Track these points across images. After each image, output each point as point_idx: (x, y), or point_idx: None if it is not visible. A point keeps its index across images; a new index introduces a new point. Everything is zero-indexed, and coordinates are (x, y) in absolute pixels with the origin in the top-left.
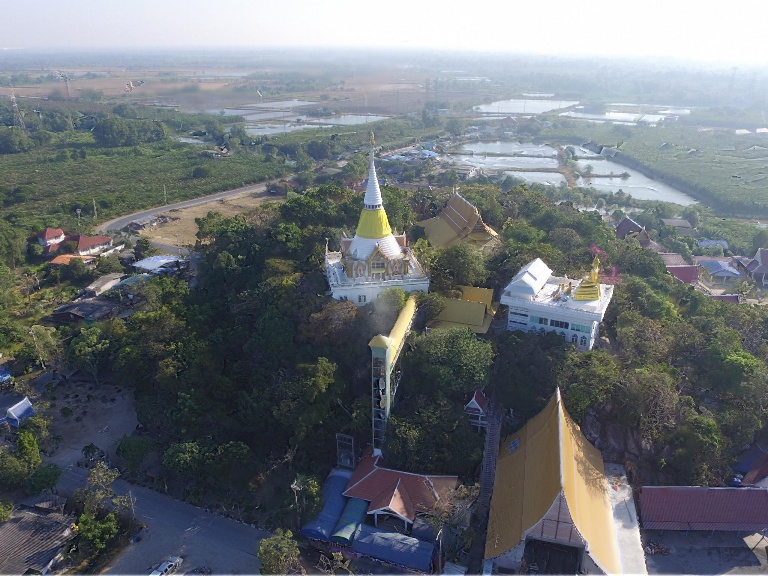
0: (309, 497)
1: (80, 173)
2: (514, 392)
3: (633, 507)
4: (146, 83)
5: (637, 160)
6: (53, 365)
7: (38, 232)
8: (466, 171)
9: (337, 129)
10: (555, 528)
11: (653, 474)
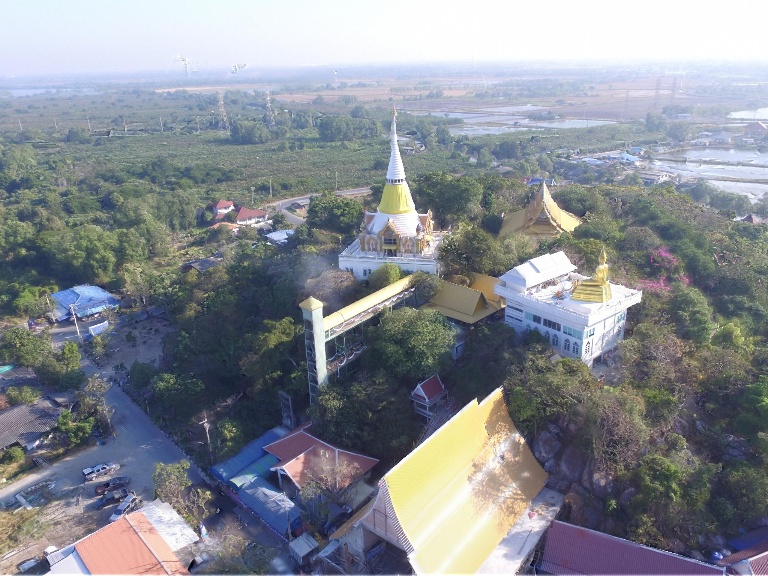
0: (226, 440)
1: (288, 161)
2: (466, 387)
3: (534, 540)
4: (248, 65)
5: None
6: (138, 300)
7: (215, 202)
8: (654, 176)
9: (546, 132)
10: (384, 522)
11: (602, 516)
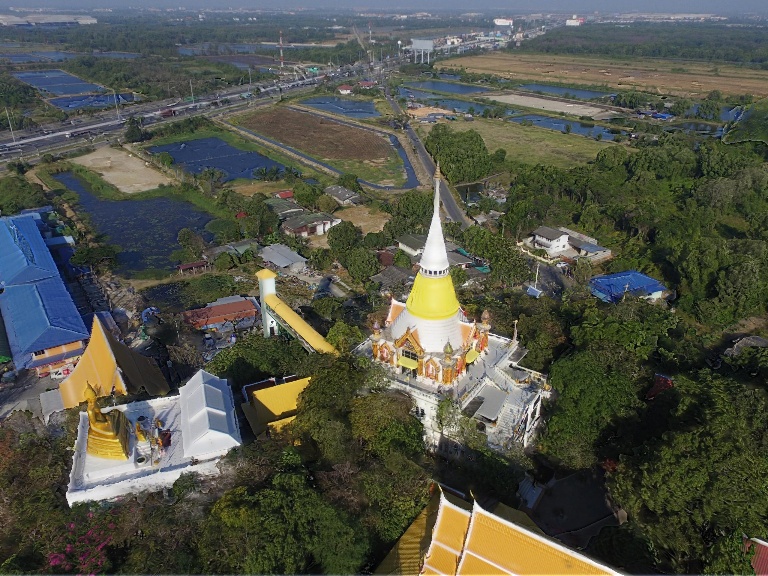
0: None
1: None
2: None
3: None
4: None
5: None
6: None
7: None
8: None
9: None
10: None
11: None
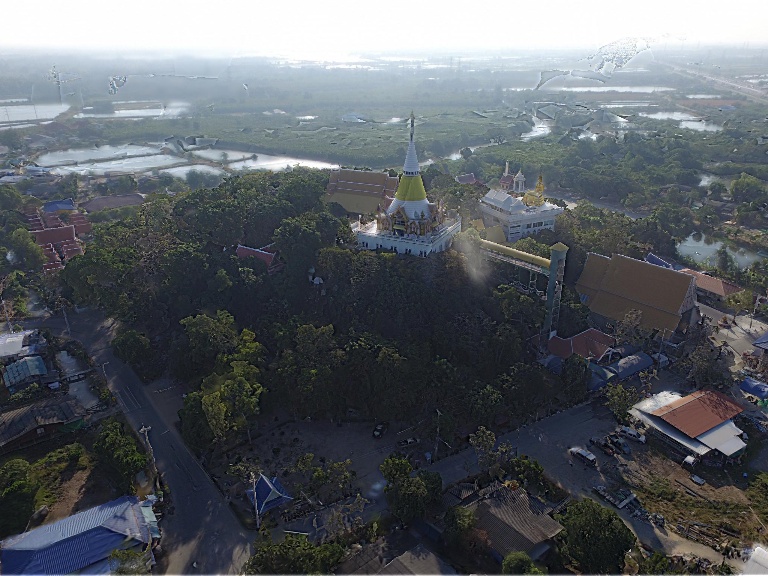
0: None
1: None
2: None
3: None
4: (129, 82)
5: (245, 143)
6: None
7: None
8: (131, 176)
9: None
10: None
11: None
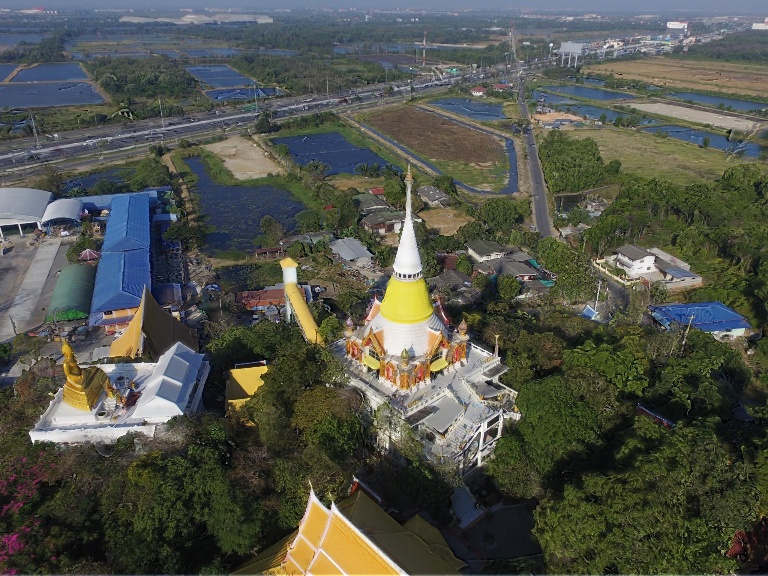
0: None
1: None
2: None
3: None
4: None
5: None
6: None
7: None
8: None
9: None
10: None
11: None
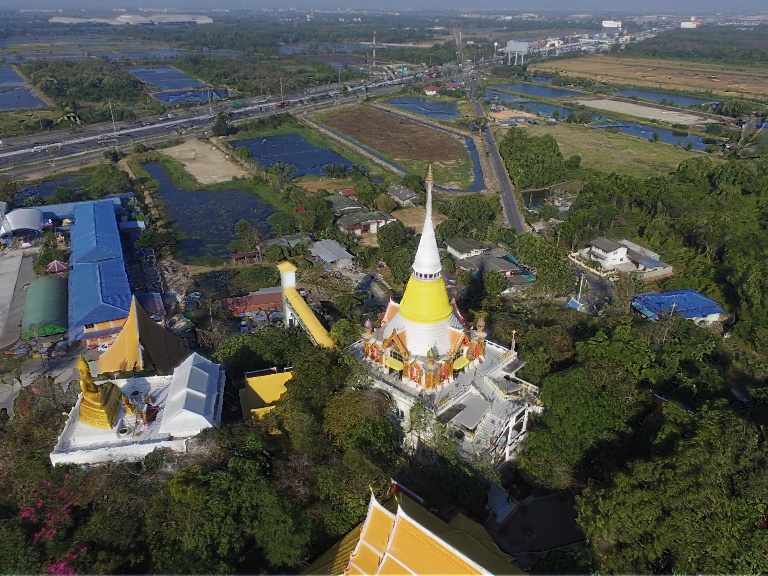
0: None
1: None
2: None
3: None
4: None
5: None
6: None
7: None
8: None
9: None
10: None
11: None
